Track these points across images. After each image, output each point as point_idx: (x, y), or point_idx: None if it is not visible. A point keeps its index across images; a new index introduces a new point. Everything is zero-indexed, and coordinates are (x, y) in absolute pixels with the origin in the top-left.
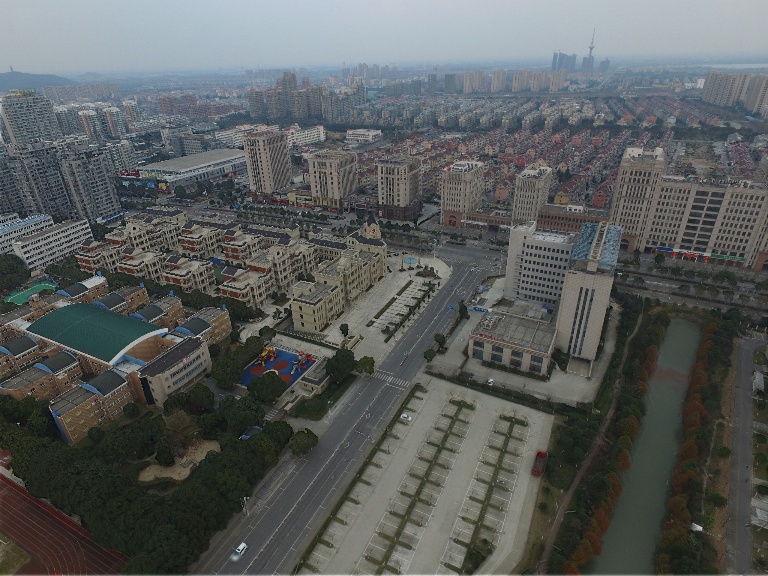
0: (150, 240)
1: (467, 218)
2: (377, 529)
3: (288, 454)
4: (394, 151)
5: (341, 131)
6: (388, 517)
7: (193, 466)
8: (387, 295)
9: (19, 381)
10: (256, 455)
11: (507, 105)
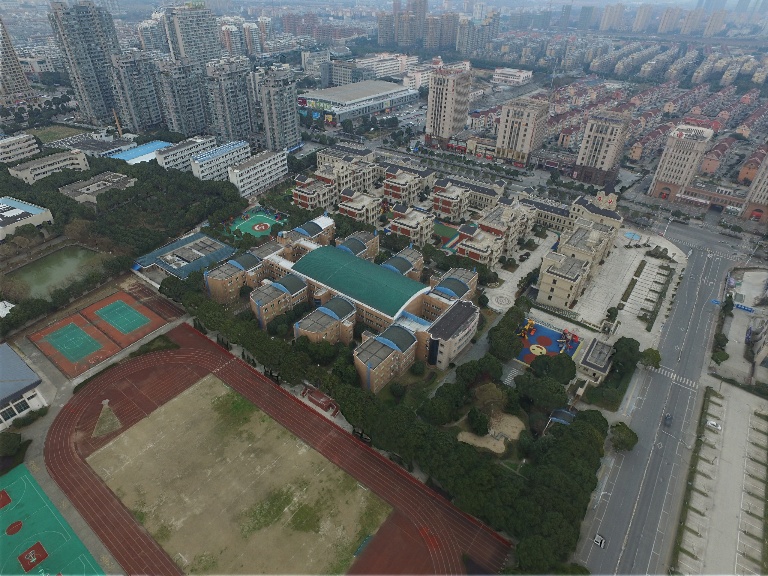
0: (352, 180)
1: (685, 192)
2: (738, 549)
3: (605, 446)
4: (561, 99)
5: (488, 69)
6: (745, 538)
7: (506, 440)
8: (624, 275)
9: (311, 323)
10: (593, 446)
11: (696, 55)
